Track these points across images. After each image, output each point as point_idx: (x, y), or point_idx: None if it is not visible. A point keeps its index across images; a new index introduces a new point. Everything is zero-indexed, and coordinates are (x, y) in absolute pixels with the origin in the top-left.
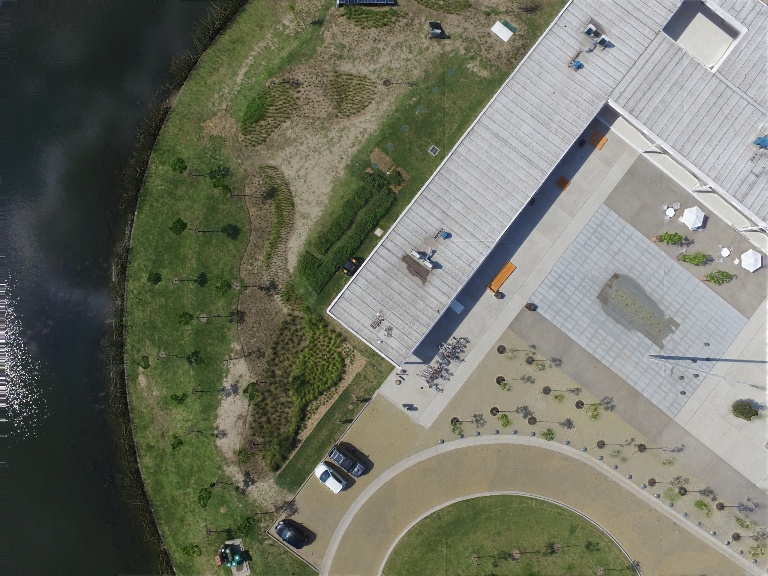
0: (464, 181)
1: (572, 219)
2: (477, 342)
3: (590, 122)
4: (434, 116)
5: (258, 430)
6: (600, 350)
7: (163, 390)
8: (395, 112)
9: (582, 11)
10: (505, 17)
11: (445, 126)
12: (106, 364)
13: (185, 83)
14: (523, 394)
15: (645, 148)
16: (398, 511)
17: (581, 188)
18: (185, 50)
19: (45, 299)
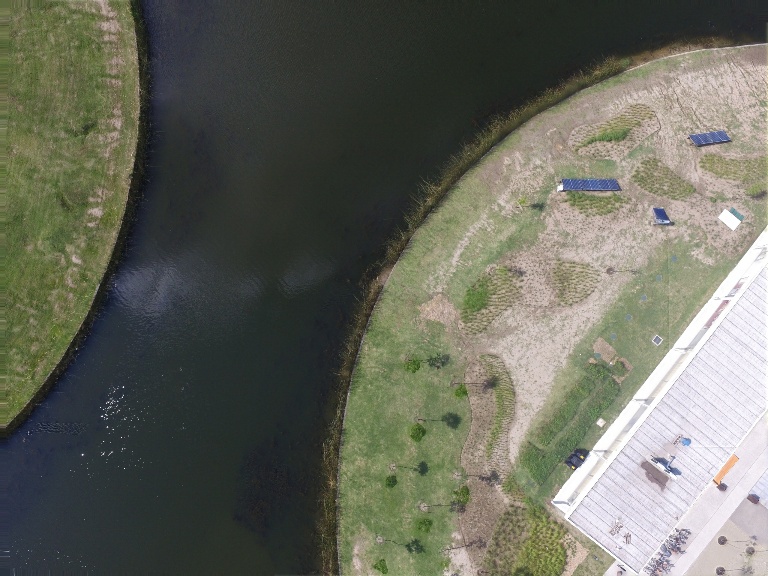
0: (704, 386)
1: None
2: (698, 533)
3: None
4: (658, 305)
5: None
6: None
7: (380, 574)
8: (618, 301)
9: None
10: (732, 204)
11: (669, 315)
12: (317, 543)
13: (397, 262)
14: None
15: None
16: None
17: None
18: (396, 228)
19: (256, 477)
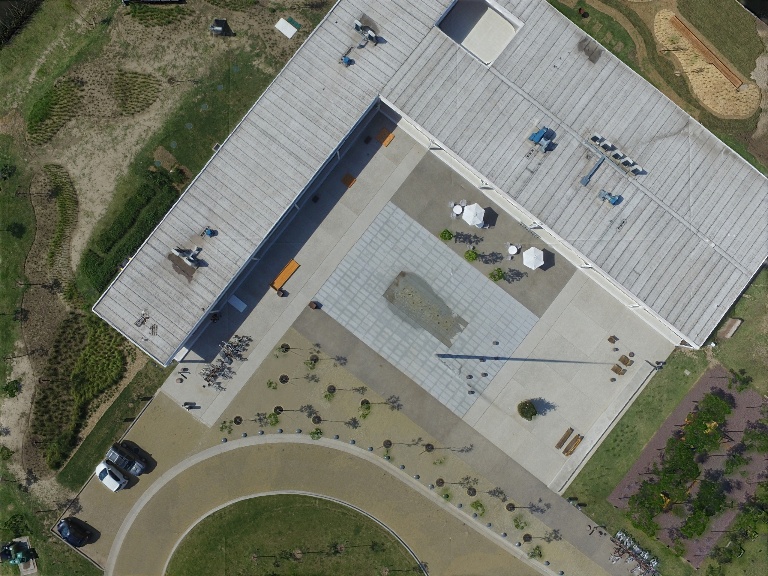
0: (231, 179)
1: (357, 217)
2: (260, 340)
3: (362, 119)
4: (218, 114)
5: (39, 428)
6: (386, 349)
7: None
8: (179, 110)
9: (354, 7)
10: (290, 14)
11: (229, 124)
12: None
13: None
14: (307, 393)
15: (429, 145)
16: (181, 510)
17: (367, 185)
18: None
19: None
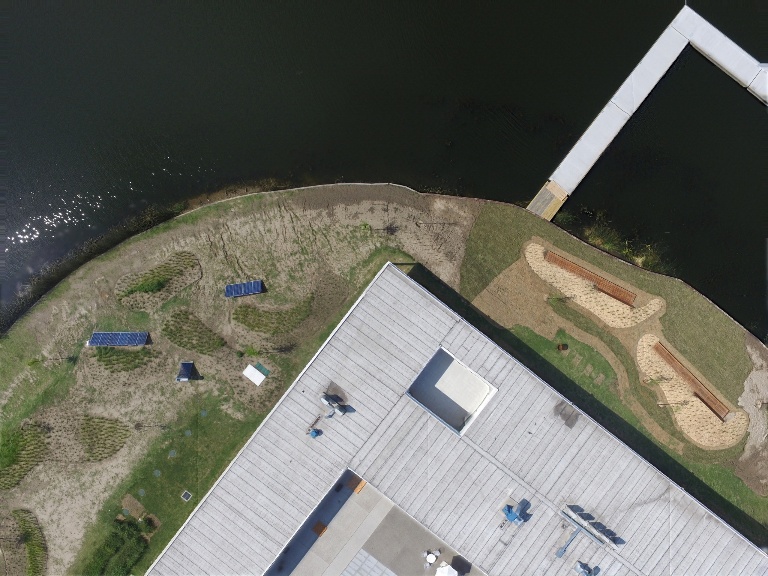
0: (197, 554)
1: (329, 565)
2: None
3: (331, 488)
4: (186, 461)
5: None
6: None
7: None
8: (147, 456)
9: (321, 374)
10: (258, 359)
11: (198, 471)
12: None
13: None
14: None
15: None
16: None
17: (338, 533)
18: None
19: None
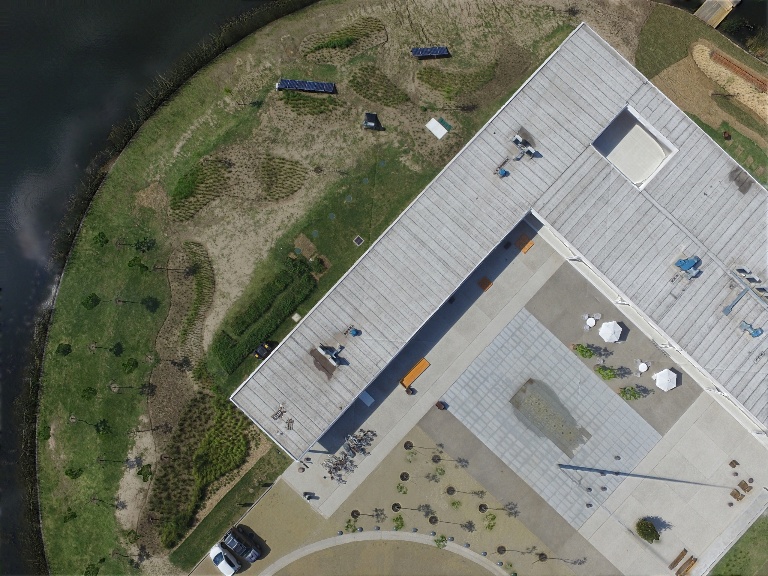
0: (379, 280)
1: (491, 320)
2: (384, 436)
3: None
4: (362, 206)
5: (157, 505)
6: (508, 455)
7: (70, 454)
8: (323, 199)
9: (513, 119)
10: (441, 114)
11: (372, 217)
12: (19, 421)
13: (123, 150)
14: (427, 492)
15: (569, 256)
16: None
17: (503, 290)
18: (127, 118)
19: None
